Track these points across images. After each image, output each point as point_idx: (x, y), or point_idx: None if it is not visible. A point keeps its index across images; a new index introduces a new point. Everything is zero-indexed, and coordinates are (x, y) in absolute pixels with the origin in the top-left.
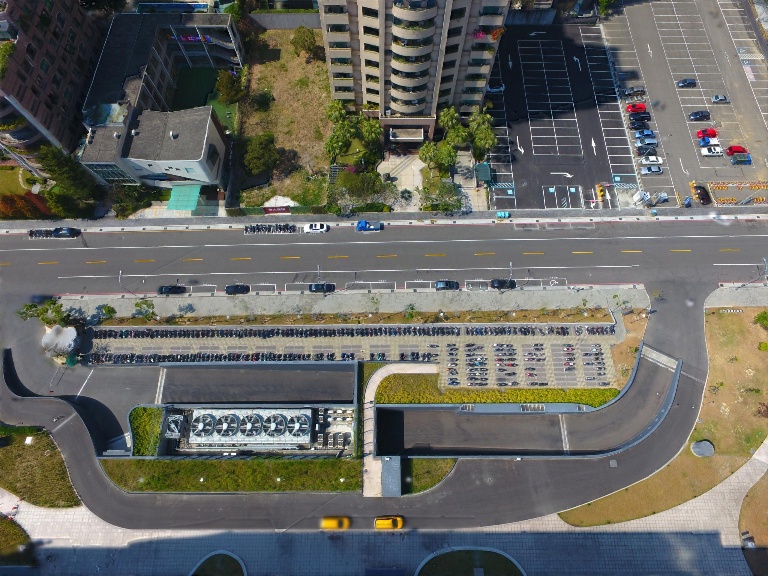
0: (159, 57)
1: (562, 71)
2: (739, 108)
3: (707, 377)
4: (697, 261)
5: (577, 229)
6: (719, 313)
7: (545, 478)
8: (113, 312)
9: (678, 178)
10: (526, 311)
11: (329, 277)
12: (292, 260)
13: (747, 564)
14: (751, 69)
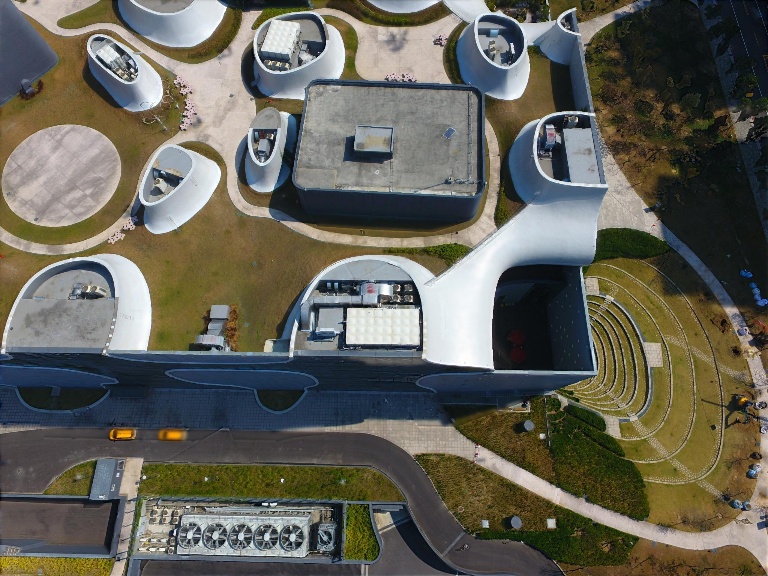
0: None
1: None
2: None
3: None
4: None
5: None
6: None
7: None
8: None
9: None
10: None
11: None
12: None
13: None
14: None
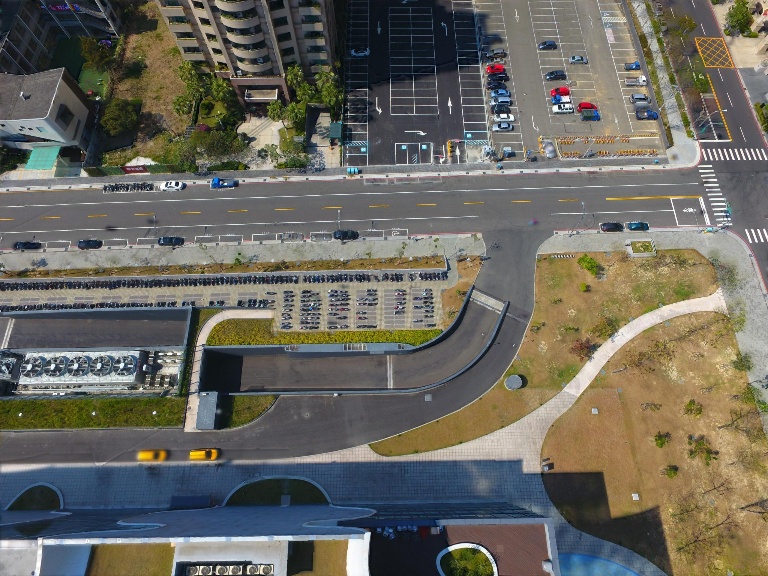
0: (26, 25)
1: (428, 36)
2: (596, 68)
3: (531, 318)
4: (536, 211)
5: (424, 183)
6: (550, 259)
7: (361, 412)
8: None
9: (528, 134)
10: (365, 260)
11: (180, 231)
12: (146, 216)
13: (544, 488)
14: (612, 31)
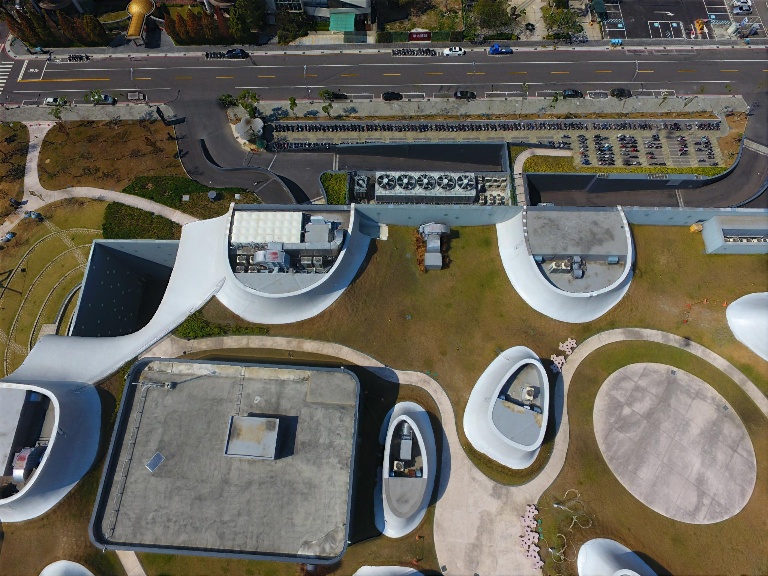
0: None
1: None
2: None
3: None
4: None
5: (681, 54)
6: None
7: None
8: (295, 105)
9: (765, 17)
10: (642, 113)
11: (470, 88)
12: (436, 76)
13: None
14: None
